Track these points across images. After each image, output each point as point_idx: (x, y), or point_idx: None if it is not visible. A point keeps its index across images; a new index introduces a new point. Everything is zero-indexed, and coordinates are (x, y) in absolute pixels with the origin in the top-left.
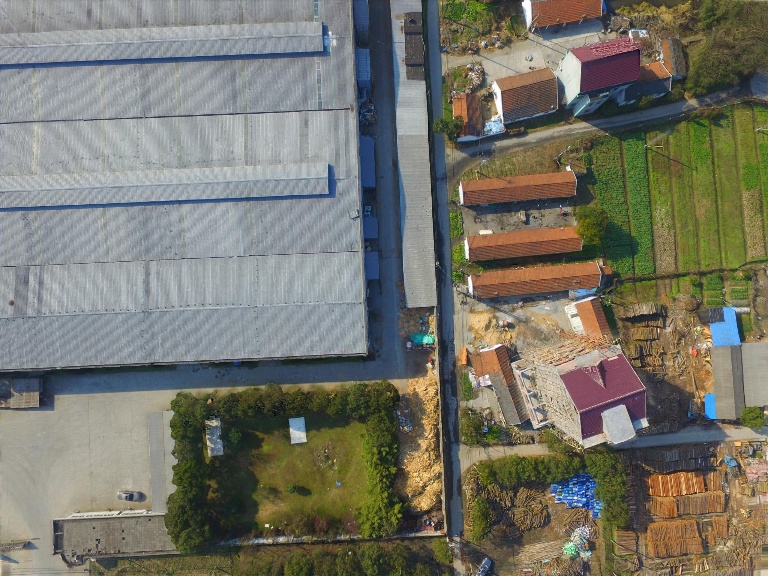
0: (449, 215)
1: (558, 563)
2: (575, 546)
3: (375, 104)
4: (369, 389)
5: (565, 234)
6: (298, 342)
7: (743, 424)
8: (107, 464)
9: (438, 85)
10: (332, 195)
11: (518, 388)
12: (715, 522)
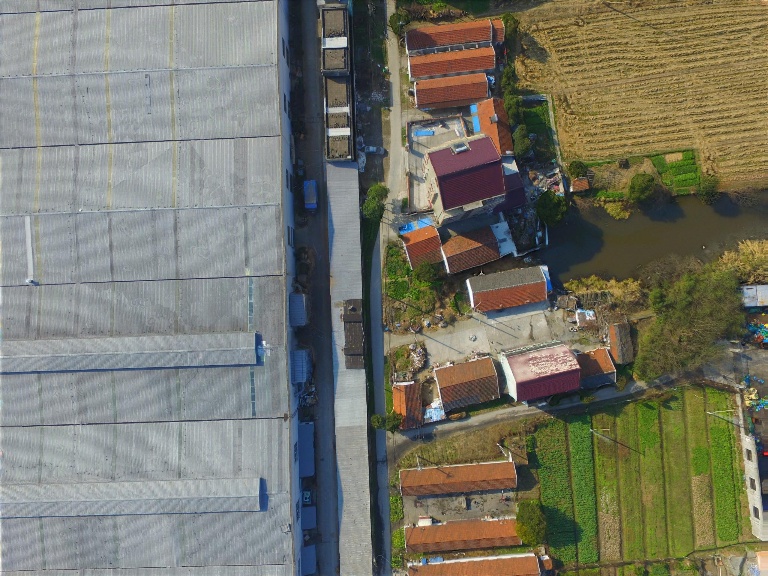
0: (389, 499)
1: None
2: None
3: (316, 384)
4: None
5: (504, 530)
6: None
7: None
8: None
9: (380, 365)
10: (264, 509)
11: None
12: None
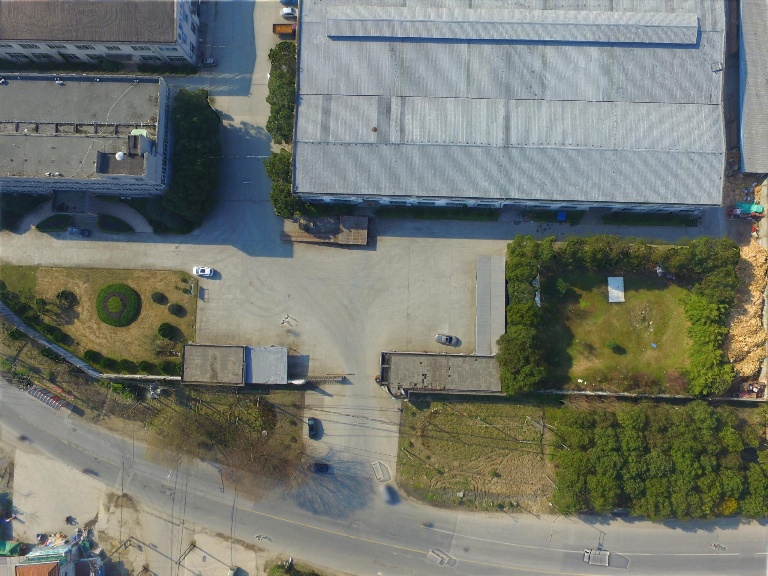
0: None
1: None
2: None
3: None
4: None
5: None
6: (653, 189)
7: None
8: (425, 307)
9: None
10: (696, 47)
11: None
12: None
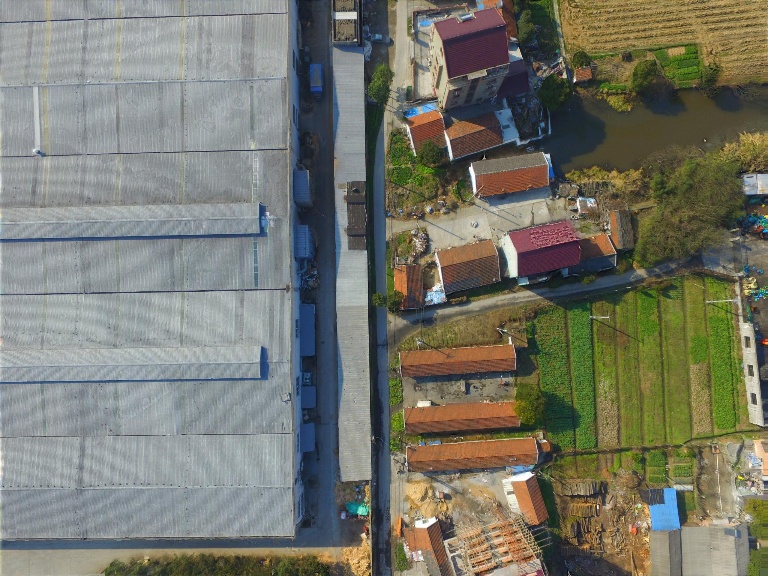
0: (389, 382)
1: None
2: None
3: (318, 268)
4: (303, 556)
5: (503, 411)
6: (227, 523)
7: None
8: None
9: (382, 250)
10: (265, 377)
11: (450, 566)
12: None
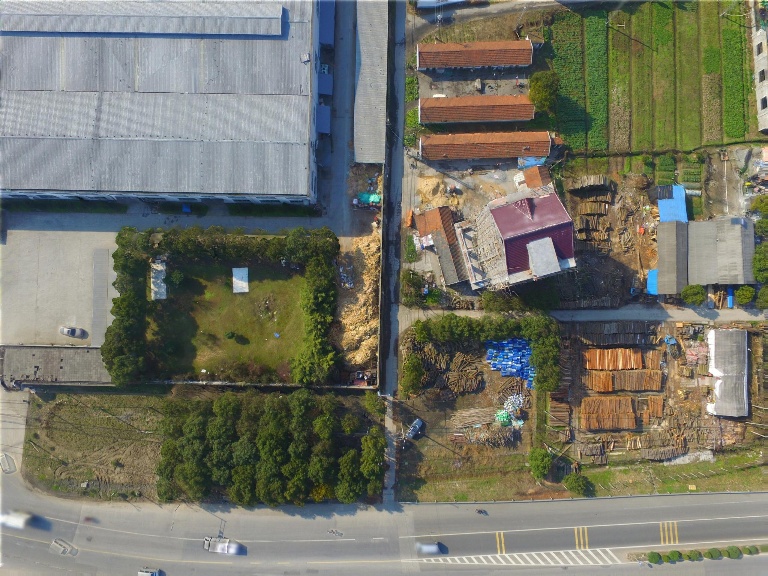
0: (405, 80)
1: (489, 428)
2: (507, 413)
3: None
4: None
5: (517, 101)
6: (241, 179)
7: (685, 302)
8: (53, 300)
9: None
10: (285, 38)
11: (460, 249)
12: (650, 400)
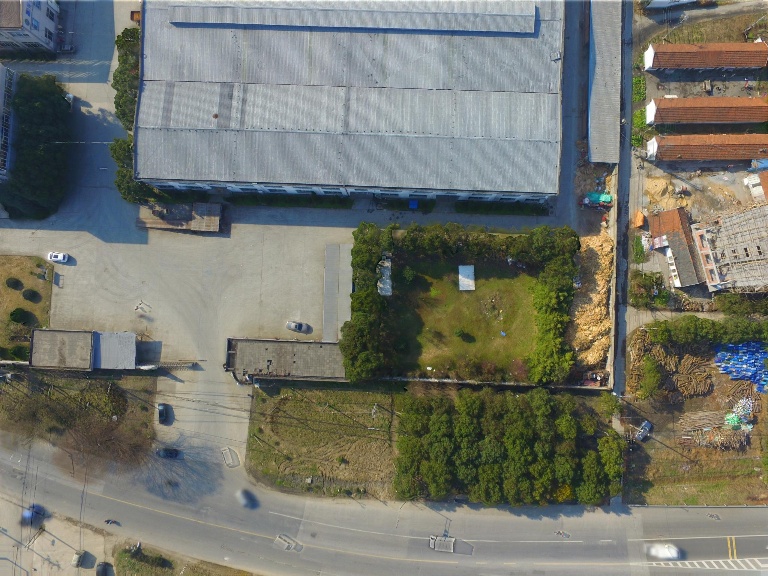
0: (632, 80)
1: (720, 431)
2: (738, 417)
3: None
4: None
5: (754, 102)
6: (490, 177)
7: None
8: (277, 294)
9: None
10: (535, 36)
11: (696, 250)
12: None
